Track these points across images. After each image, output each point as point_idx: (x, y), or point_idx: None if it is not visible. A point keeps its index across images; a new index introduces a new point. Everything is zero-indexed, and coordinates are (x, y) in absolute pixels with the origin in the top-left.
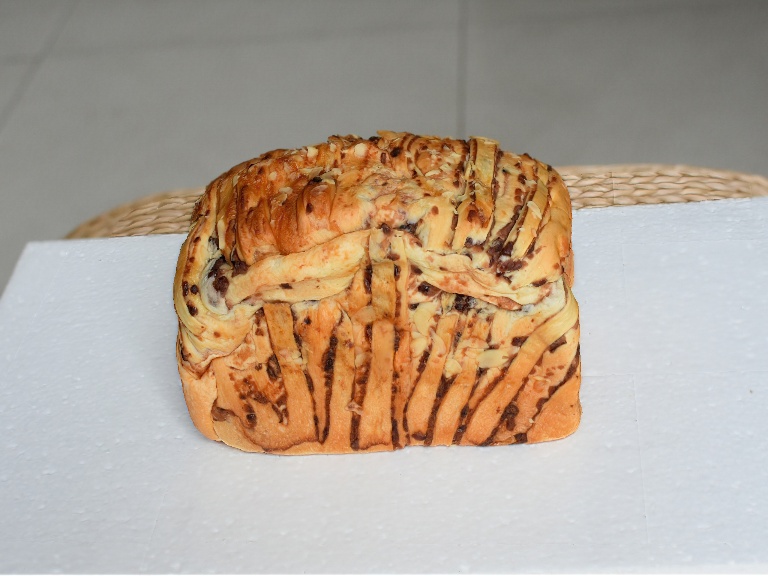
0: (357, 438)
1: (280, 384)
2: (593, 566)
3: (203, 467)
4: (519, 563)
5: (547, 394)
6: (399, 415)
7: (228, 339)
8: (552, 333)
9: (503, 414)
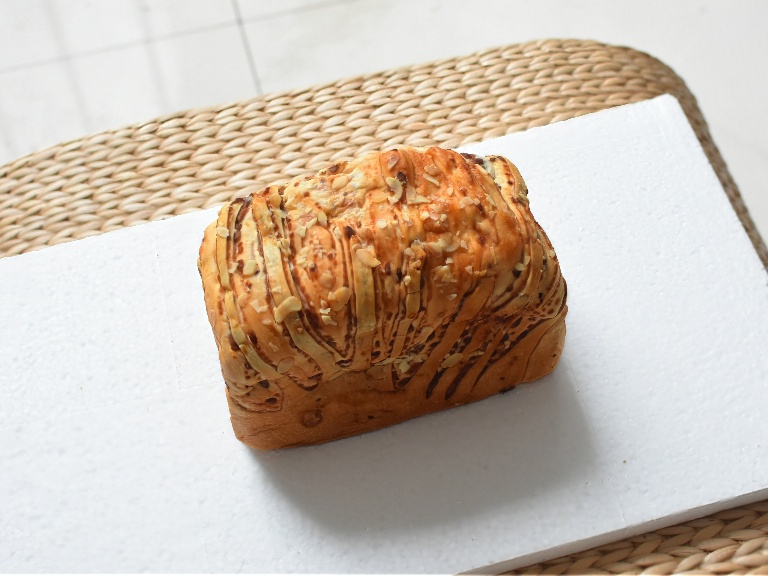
0: None
1: None
2: (190, 216)
3: None
4: None
5: None
6: None
7: None
8: None
9: None
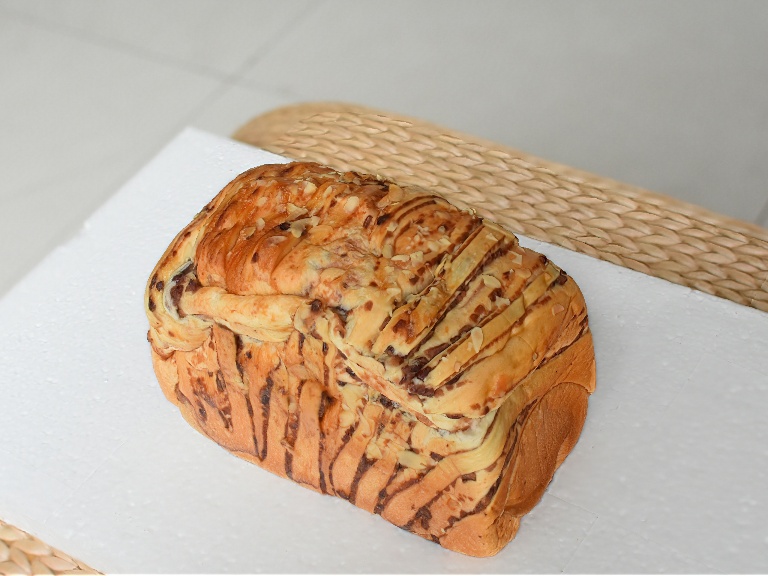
0: (291, 470)
1: (225, 397)
2: None
3: (165, 433)
4: None
5: (459, 515)
6: (325, 469)
7: (183, 340)
8: (462, 466)
9: (417, 512)
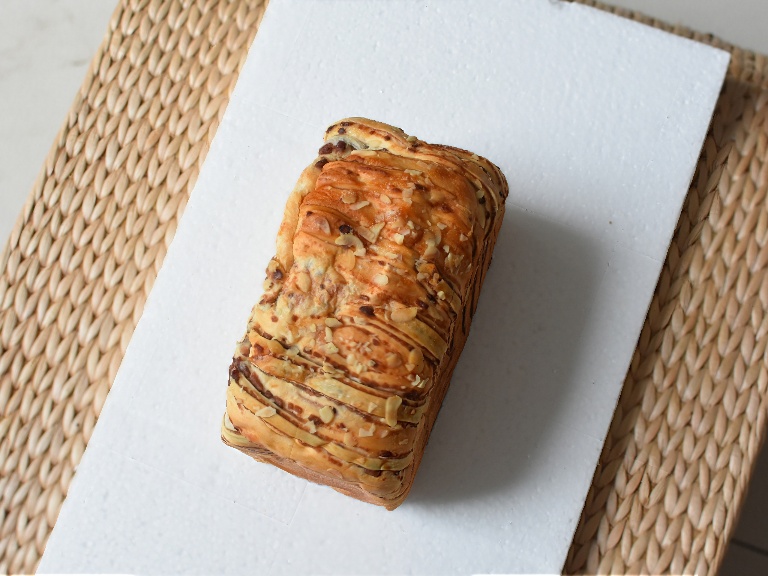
0: None
1: None
2: (109, 403)
3: None
4: (132, 353)
5: None
6: None
7: None
8: None
9: None
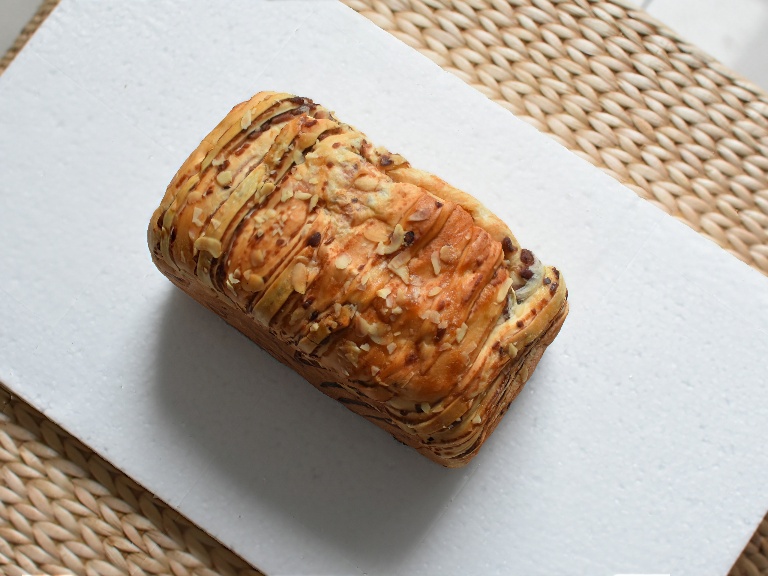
0: None
1: None
2: (361, 19)
3: None
4: (405, 51)
5: None
6: None
7: None
8: None
9: None
